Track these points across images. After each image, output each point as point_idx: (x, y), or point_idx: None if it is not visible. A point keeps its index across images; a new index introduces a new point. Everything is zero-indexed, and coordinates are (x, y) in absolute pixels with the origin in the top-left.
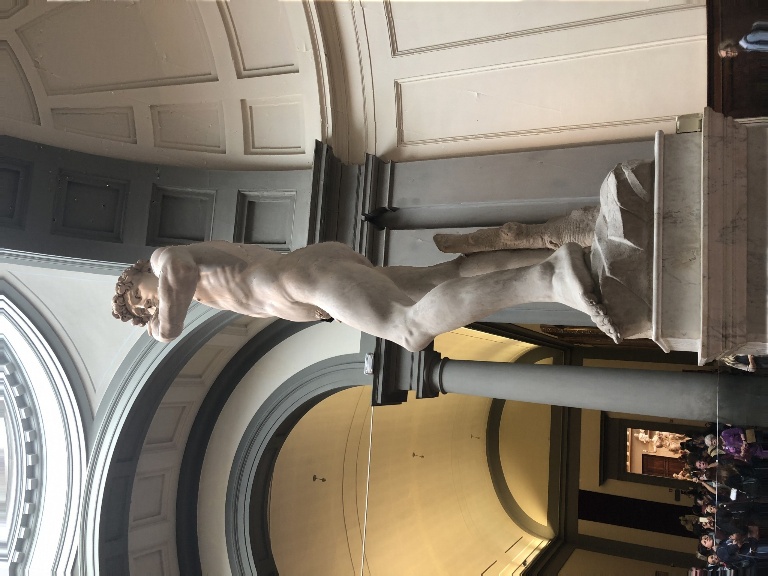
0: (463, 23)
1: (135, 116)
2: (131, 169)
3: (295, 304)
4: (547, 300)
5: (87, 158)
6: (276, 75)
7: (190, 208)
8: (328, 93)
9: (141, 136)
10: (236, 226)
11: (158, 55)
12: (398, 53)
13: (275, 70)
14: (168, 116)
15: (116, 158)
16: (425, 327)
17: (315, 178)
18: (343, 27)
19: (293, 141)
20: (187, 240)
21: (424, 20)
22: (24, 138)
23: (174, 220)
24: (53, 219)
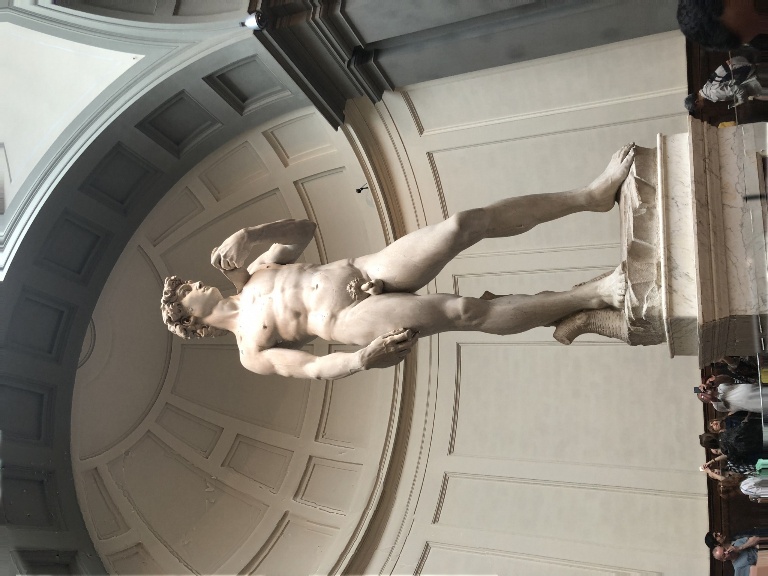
0: None
1: (121, 536)
2: (79, 532)
3: (349, 266)
4: (583, 189)
5: (71, 494)
6: None
7: None
8: None
9: (108, 542)
10: None
11: (184, 537)
12: None
13: None
14: (139, 561)
15: None
16: None
17: None
18: None
19: None
20: None
21: None
22: None
23: None
24: (4, 466)
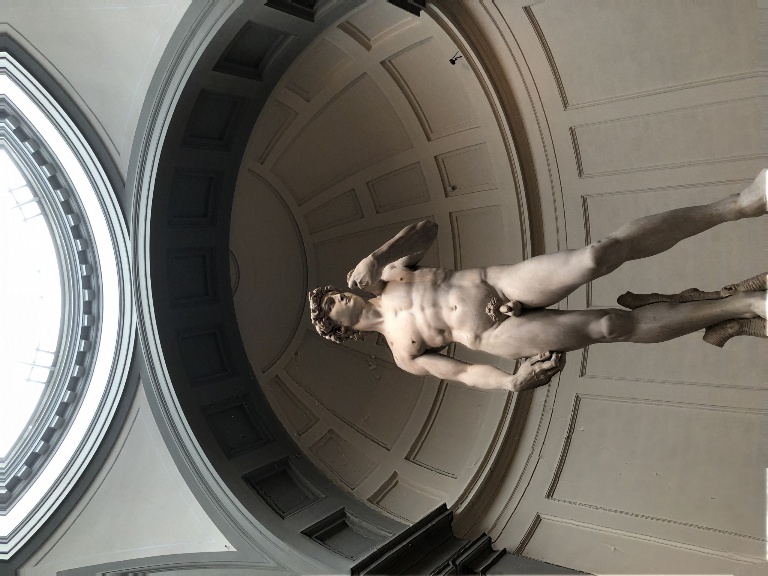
0: (621, 500)
1: (314, 426)
2: (284, 438)
3: (483, 283)
4: (732, 205)
5: (267, 407)
6: (436, 472)
7: (294, 493)
8: (476, 489)
9: (307, 436)
10: (320, 523)
11: (363, 413)
12: (552, 498)
13: (437, 471)
14: (334, 444)
15: (282, 425)
16: (615, 235)
17: (427, 518)
18: (515, 464)
19: (414, 517)
20: (272, 502)
21: (587, 487)
22: (251, 363)
23: (275, 488)
24: (211, 405)
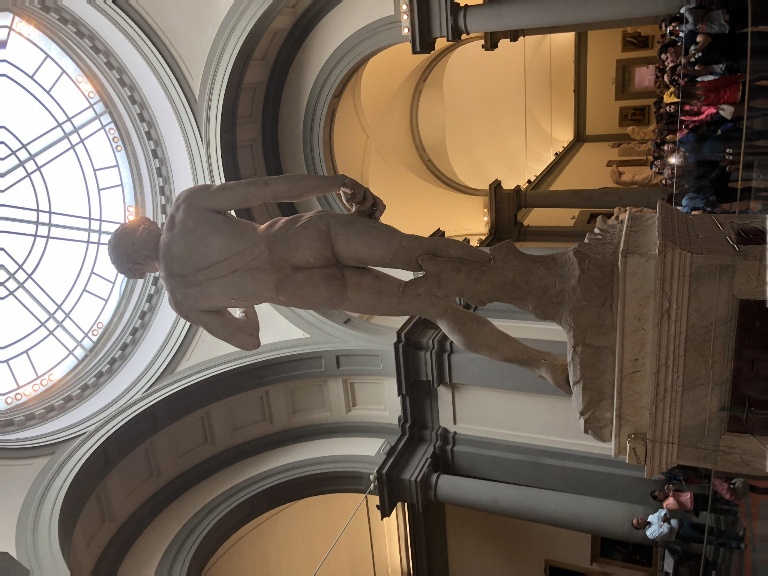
0: None
1: None
2: None
3: None
4: None
5: None
6: None
7: None
8: None
9: None
10: None
11: None
12: None
13: None
14: None
15: None
16: None
17: None
18: None
19: None
20: None
21: None
22: None
23: None
24: None
